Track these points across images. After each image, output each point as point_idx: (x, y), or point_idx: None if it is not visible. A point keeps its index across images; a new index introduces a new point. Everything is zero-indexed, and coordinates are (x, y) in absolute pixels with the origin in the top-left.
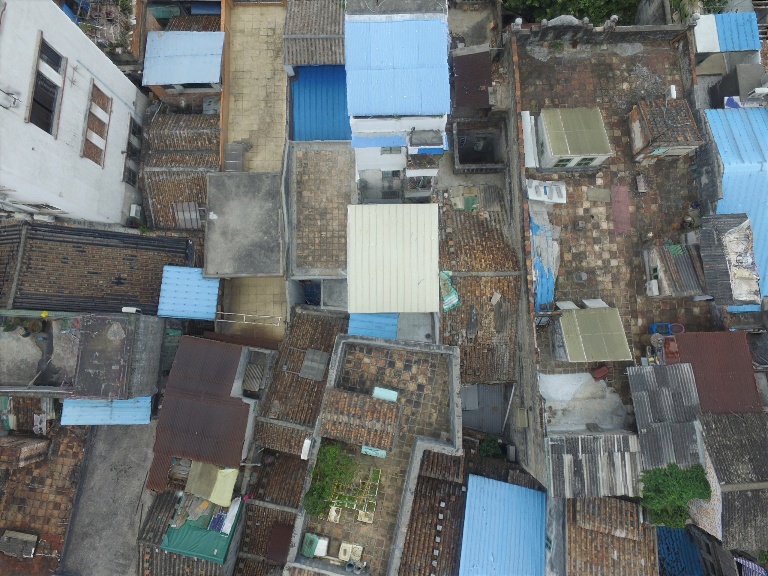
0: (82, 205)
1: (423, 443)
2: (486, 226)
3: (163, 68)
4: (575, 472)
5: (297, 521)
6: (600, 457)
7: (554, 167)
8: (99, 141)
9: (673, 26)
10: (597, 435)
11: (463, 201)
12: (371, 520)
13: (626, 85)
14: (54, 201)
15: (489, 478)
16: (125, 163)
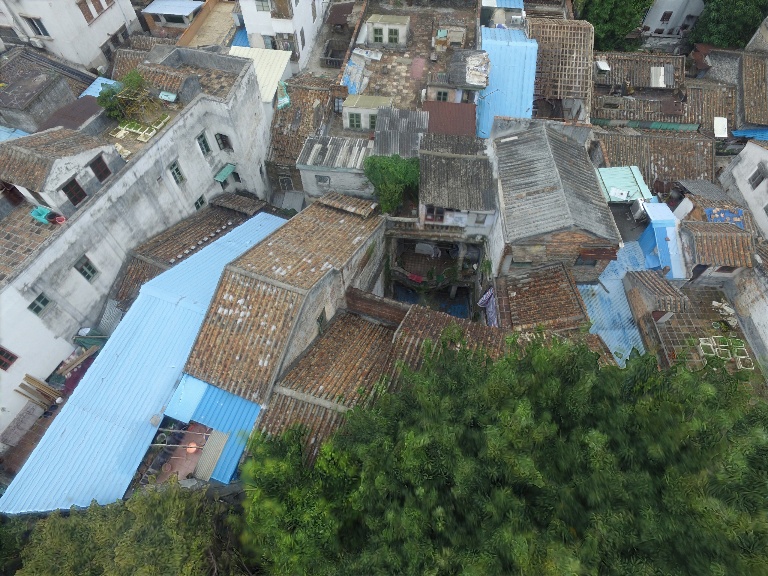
0: (62, 26)
1: (203, 94)
2: (329, 81)
3: (158, 8)
4: (320, 153)
5: (90, 118)
6: (343, 148)
7: (375, 42)
8: (94, 11)
9: None
10: (345, 138)
11: (320, 75)
12: (147, 139)
13: None
14: (45, 13)
15: (276, 216)
16: (107, 41)
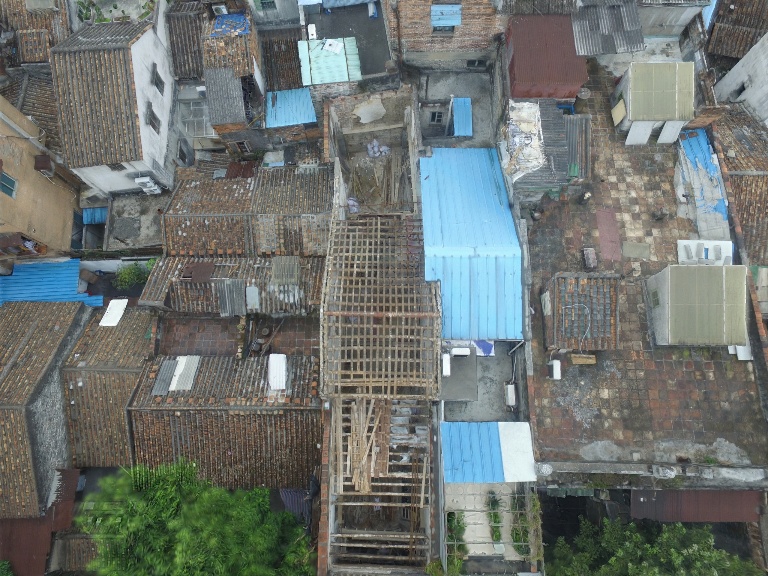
0: None
1: None
2: None
3: None
4: None
5: None
6: None
7: None
8: None
9: (562, 468)
10: (666, 3)
11: (759, 278)
12: None
13: (604, 394)
14: None
15: None
16: None
